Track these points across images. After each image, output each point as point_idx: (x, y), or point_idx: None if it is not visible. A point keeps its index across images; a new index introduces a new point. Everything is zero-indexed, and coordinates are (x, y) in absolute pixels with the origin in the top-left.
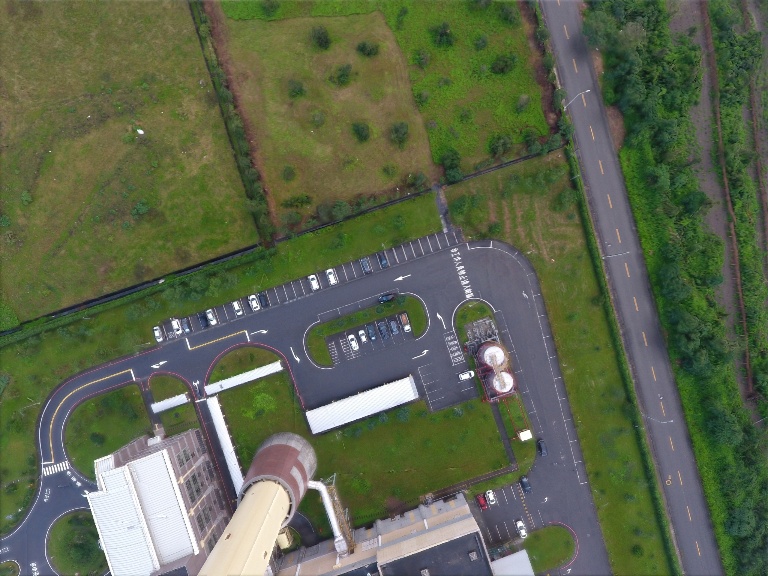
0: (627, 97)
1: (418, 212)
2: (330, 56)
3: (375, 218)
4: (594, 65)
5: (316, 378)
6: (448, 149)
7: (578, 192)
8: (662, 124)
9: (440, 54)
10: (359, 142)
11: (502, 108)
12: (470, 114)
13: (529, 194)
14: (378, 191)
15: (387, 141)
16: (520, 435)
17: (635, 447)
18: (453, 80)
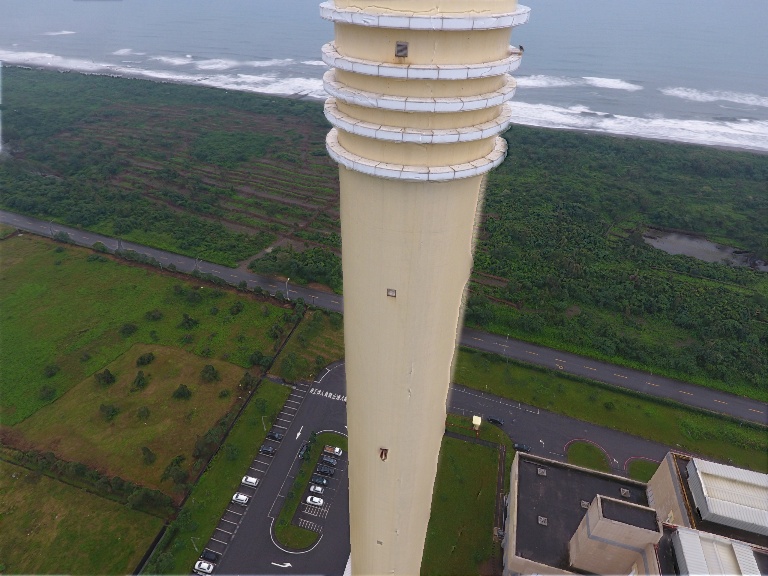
0: (308, 270)
1: (267, 395)
2: (120, 383)
3: (242, 422)
4: (281, 280)
5: (318, 560)
6: (248, 357)
7: (337, 312)
8: (337, 271)
9: (195, 331)
10: (187, 400)
11: (257, 322)
12: (243, 336)
13: (317, 336)
14: (228, 410)
15: (206, 385)
16: (474, 423)
17: (524, 370)
18: (216, 333)
